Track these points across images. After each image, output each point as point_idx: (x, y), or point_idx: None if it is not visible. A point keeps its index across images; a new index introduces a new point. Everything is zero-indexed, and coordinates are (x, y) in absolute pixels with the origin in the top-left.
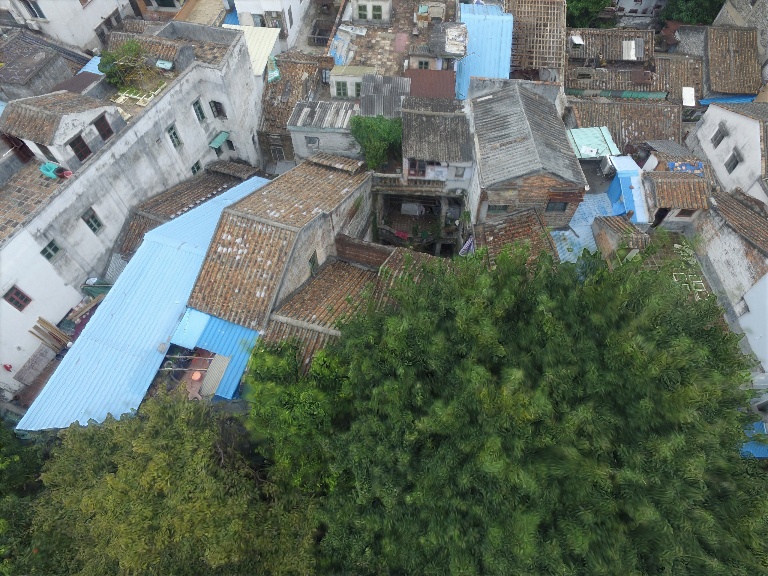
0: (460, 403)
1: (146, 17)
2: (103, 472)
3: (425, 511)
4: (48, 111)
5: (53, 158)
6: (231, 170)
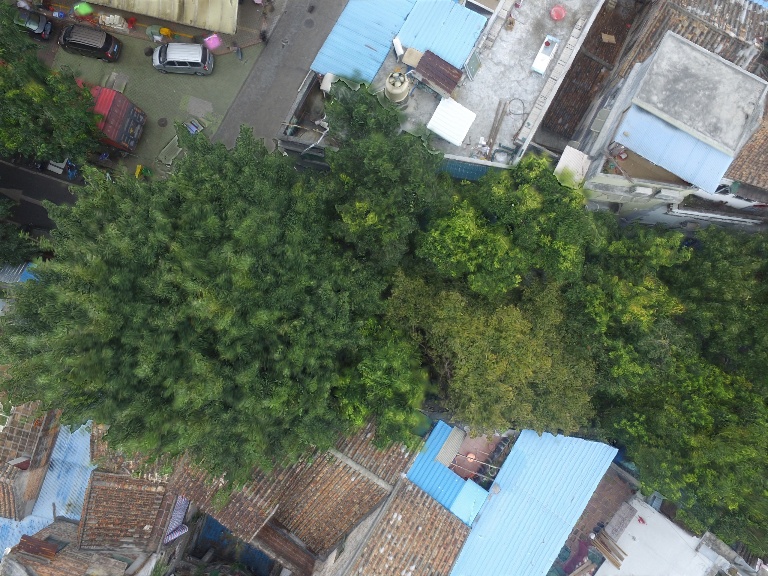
0: (249, 329)
1: None
2: None
3: None
4: None
5: None
6: None
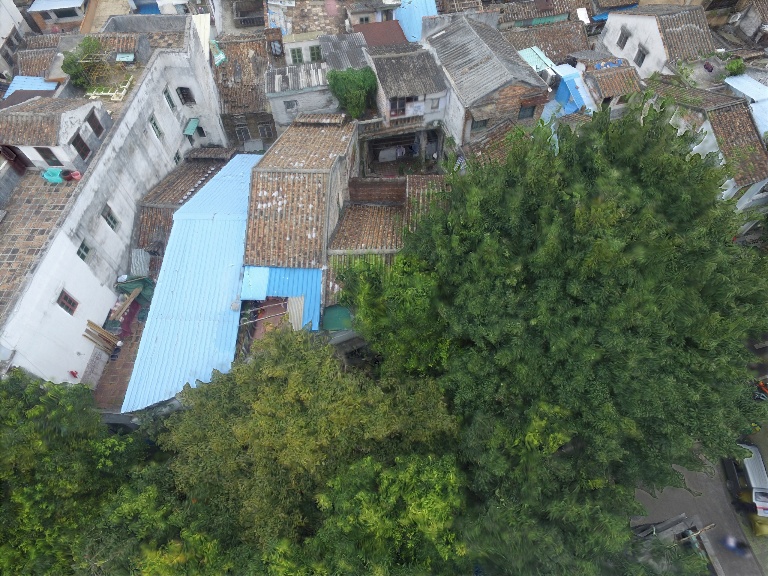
0: None
1: (46, 32)
2: (230, 418)
3: (545, 332)
4: (43, 113)
5: (56, 162)
6: (211, 154)
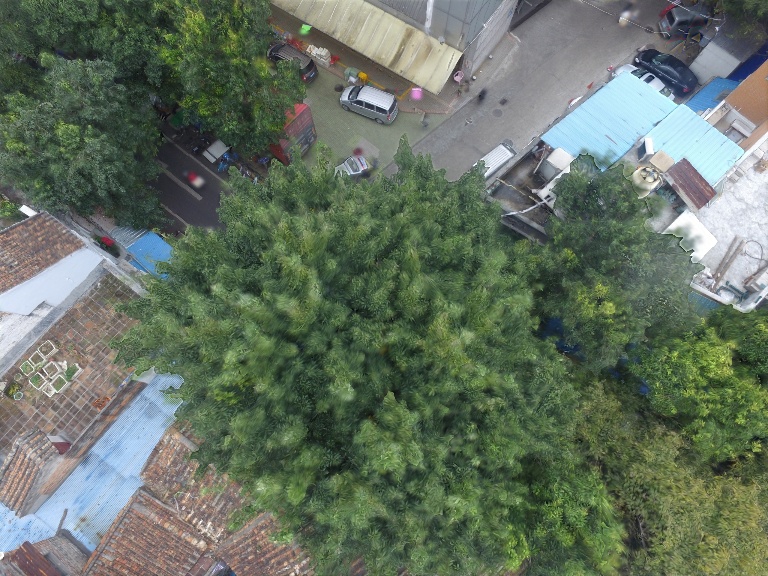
0: (458, 385)
1: None
2: None
3: None
4: None
5: None
6: None
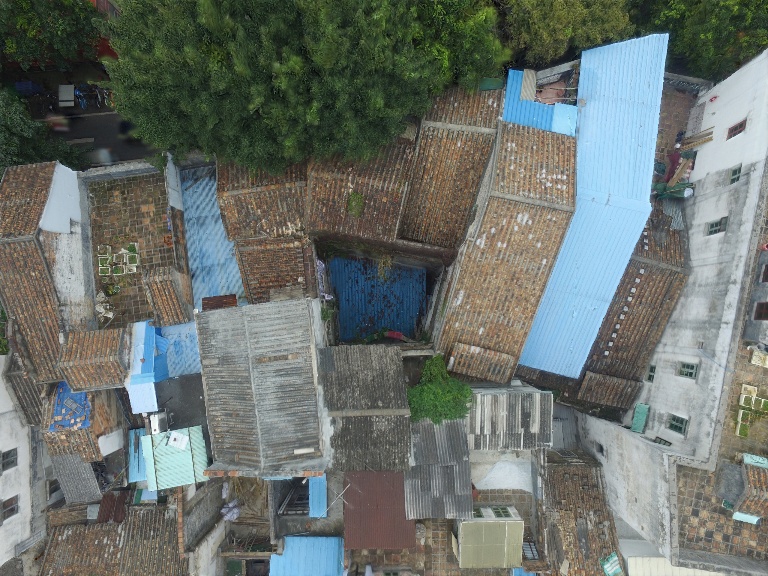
0: None
1: None
2: None
3: None
4: None
5: None
6: (610, 384)
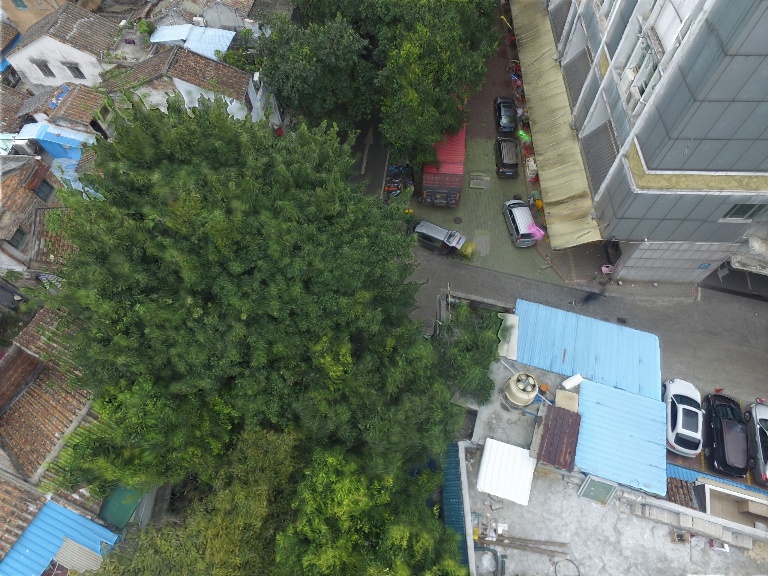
0: None
1: None
2: None
3: None
4: None
5: None
6: None
